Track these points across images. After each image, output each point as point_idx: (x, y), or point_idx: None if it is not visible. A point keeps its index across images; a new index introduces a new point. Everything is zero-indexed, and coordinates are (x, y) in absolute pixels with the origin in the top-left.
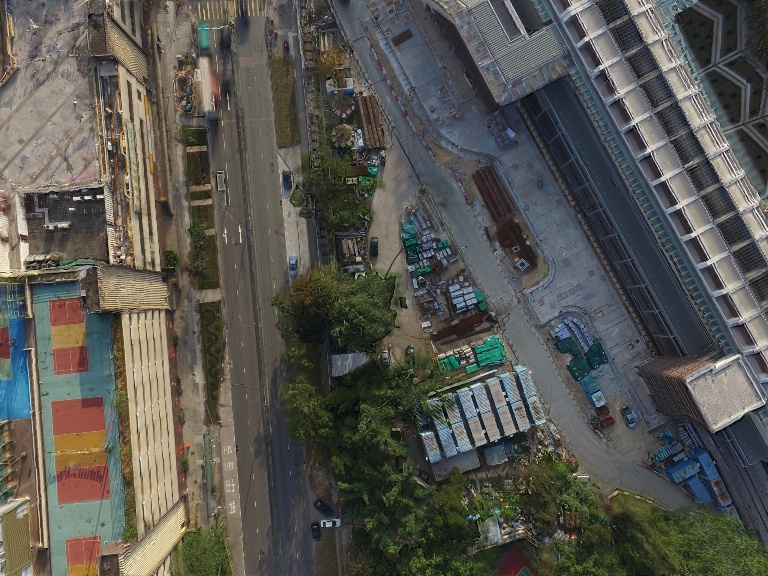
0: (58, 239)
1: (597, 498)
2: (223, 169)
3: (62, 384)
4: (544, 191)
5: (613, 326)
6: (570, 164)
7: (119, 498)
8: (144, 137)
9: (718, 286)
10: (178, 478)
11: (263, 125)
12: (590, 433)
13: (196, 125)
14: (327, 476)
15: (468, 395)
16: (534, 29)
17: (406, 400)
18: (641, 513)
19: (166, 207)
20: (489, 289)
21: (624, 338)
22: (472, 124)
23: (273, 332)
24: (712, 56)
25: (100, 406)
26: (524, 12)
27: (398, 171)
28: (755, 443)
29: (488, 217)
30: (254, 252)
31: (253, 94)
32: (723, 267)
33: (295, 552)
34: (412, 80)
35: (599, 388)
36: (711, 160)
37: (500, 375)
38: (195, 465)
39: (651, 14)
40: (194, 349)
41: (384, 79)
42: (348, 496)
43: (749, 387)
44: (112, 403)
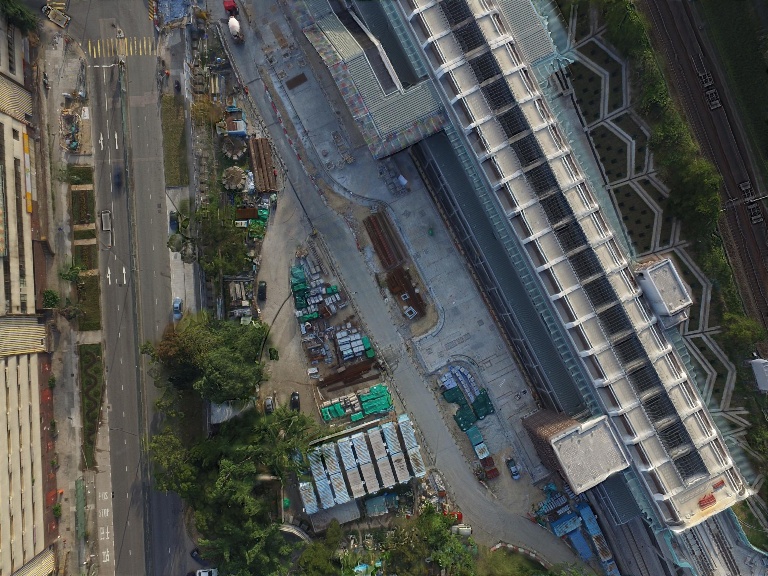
0: None
1: (480, 550)
2: (109, 209)
3: None
4: (435, 239)
5: (501, 376)
6: (454, 215)
7: None
8: (21, 177)
9: (585, 346)
10: (45, 527)
11: (152, 165)
12: (476, 484)
13: (82, 163)
14: None
15: (348, 445)
16: (412, 83)
17: (268, 456)
18: (516, 569)
19: (47, 246)
20: (378, 336)
21: (511, 389)
22: (365, 170)
23: None
24: (601, 111)
25: None
26: (403, 66)
27: (290, 215)
28: (628, 501)
29: (378, 264)
30: (138, 294)
31: (142, 134)
32: (590, 328)
33: None
34: (305, 124)
35: (484, 439)
36: (579, 221)
37: (383, 425)
38: (68, 512)
39: (524, 74)
40: (72, 392)
41: (278, 122)
42: (209, 552)
43: (615, 448)
44: None
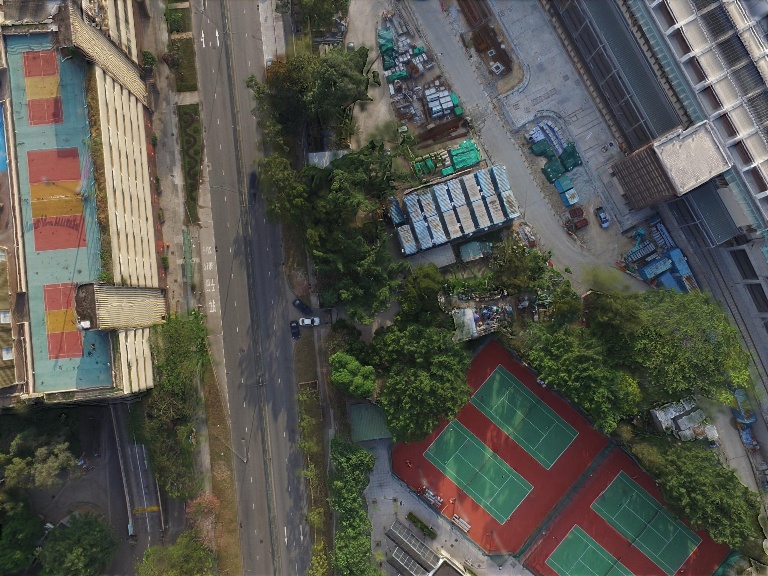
0: (33, 9)
1: None
2: None
3: (38, 134)
4: None
5: (587, 130)
6: None
7: (95, 246)
8: None
9: (685, 51)
10: (158, 268)
11: None
12: (564, 236)
13: None
14: (306, 276)
15: (443, 189)
16: None
17: (379, 165)
18: None
19: (143, 7)
20: (465, 95)
21: (598, 141)
22: None
23: (251, 135)
24: None
25: (75, 156)
26: None
27: None
28: (723, 222)
29: (463, 22)
30: (231, 55)
31: None
32: (690, 32)
33: (275, 350)
34: None
35: None
36: None
37: None
38: (175, 264)
39: None
40: (173, 151)
41: None
42: (323, 266)
43: (716, 152)
44: (87, 152)
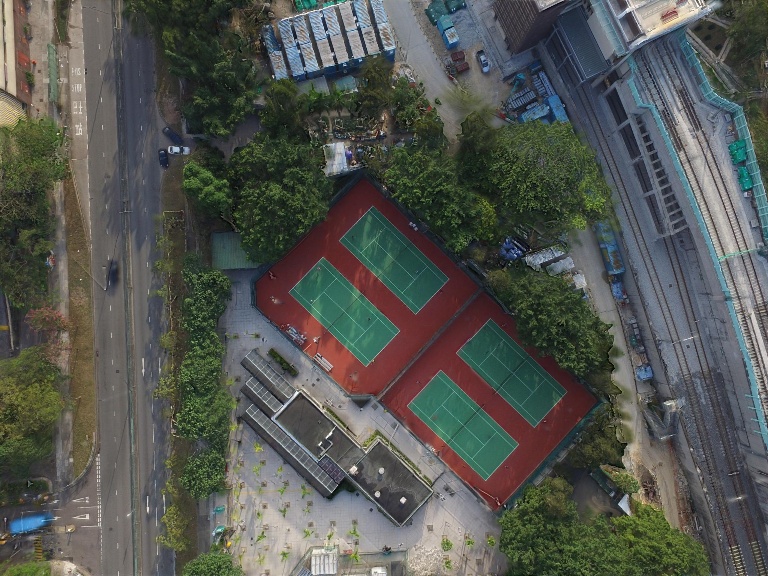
0: None
1: None
2: None
3: None
4: None
5: None
6: None
7: None
8: None
9: None
10: (17, 79)
11: None
12: (446, 81)
13: None
14: None
15: (318, 17)
16: None
17: None
18: None
19: None
20: None
21: None
22: None
23: None
24: None
25: None
26: None
27: None
28: (593, 56)
29: None
30: None
31: None
32: None
33: (141, 178)
34: None
35: None
36: None
37: None
38: (41, 83)
39: None
40: None
41: None
42: (177, 69)
43: None
44: None
